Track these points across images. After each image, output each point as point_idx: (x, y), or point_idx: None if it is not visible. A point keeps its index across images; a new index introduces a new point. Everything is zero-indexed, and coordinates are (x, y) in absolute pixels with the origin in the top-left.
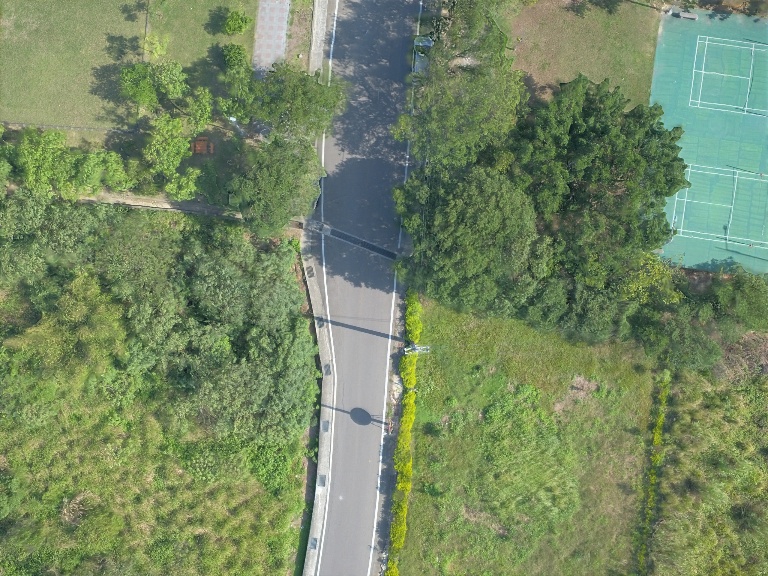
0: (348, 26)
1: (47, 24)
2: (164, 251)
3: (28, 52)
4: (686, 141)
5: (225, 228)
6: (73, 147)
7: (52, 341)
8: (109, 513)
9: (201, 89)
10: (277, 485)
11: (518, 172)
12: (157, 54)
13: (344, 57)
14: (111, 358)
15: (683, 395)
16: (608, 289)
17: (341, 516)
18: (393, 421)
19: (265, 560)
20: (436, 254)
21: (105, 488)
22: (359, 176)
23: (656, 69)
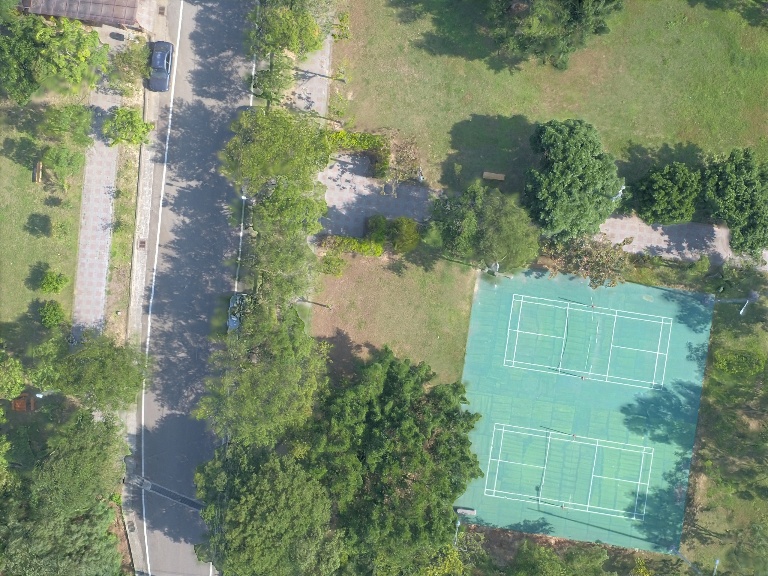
0: (167, 281)
1: None
2: None
3: None
4: (500, 401)
5: None
6: None
7: None
8: None
9: (11, 360)
10: None
11: (315, 459)
12: None
13: (163, 313)
14: None
15: None
16: (408, 569)
17: None
18: None
19: None
20: (226, 551)
21: None
22: (178, 433)
23: (471, 328)
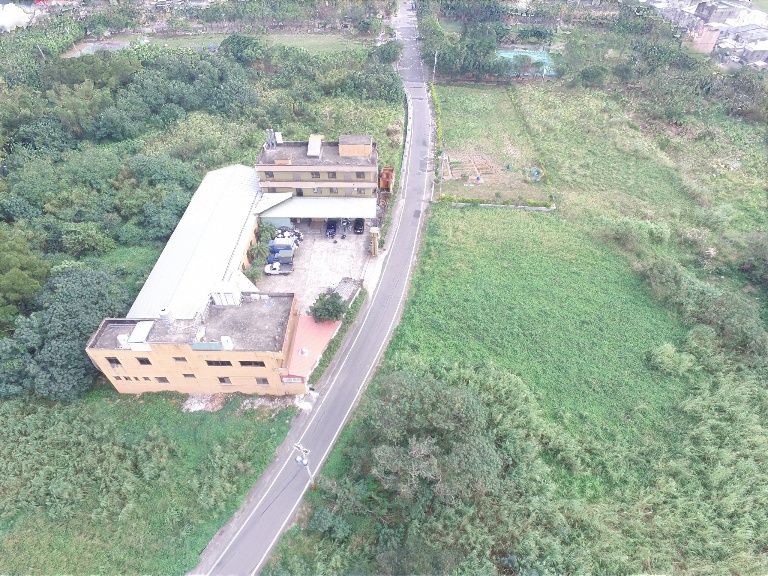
0: None
1: None
2: None
3: None
4: None
5: None
6: None
7: None
8: None
9: None
10: None
11: None
12: None
13: (401, 58)
14: None
15: None
16: None
17: (418, 113)
18: None
19: None
20: None
21: None
22: None
23: None
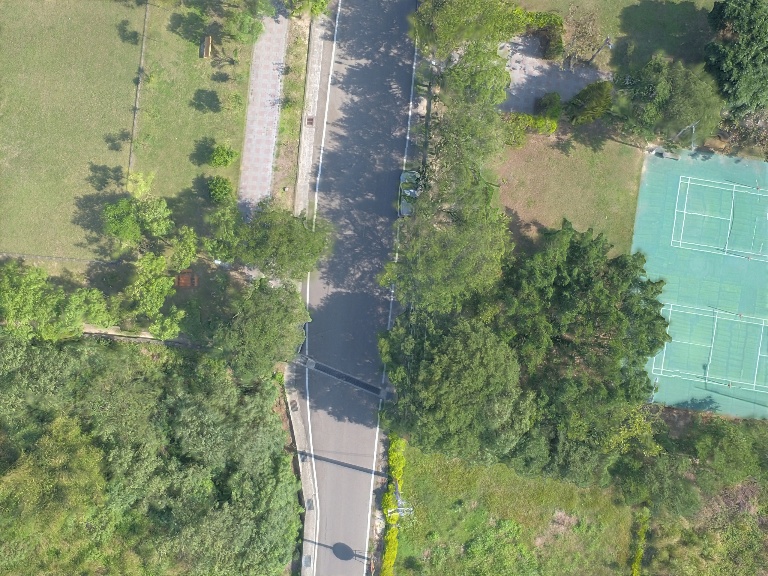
0: (334, 159)
1: (29, 151)
2: (147, 397)
3: (9, 179)
4: (667, 281)
5: (208, 361)
6: (54, 276)
7: (31, 480)
8: None
9: (186, 228)
10: None
11: (502, 323)
12: (141, 191)
13: (330, 190)
14: (92, 502)
15: (662, 532)
16: (590, 437)
17: None
18: (375, 556)
19: None
20: (420, 410)
21: None
22: (344, 310)
23: (639, 208)
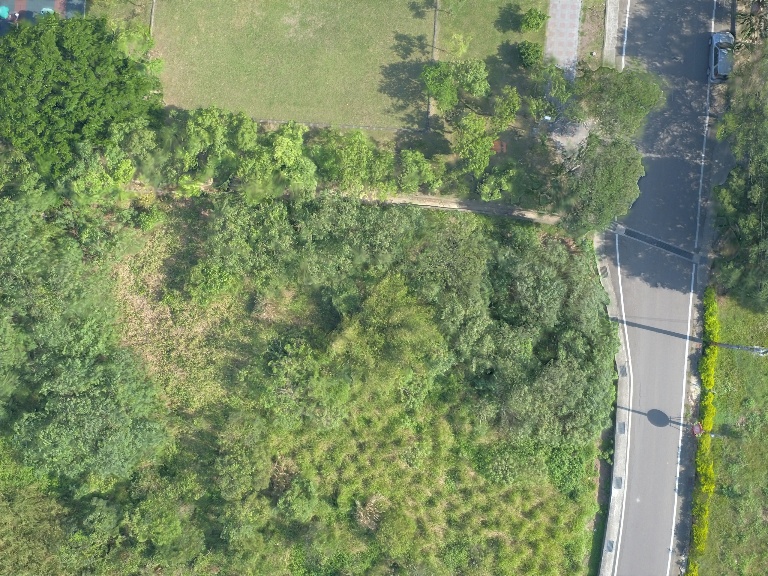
0: (641, 23)
1: (333, 22)
2: (484, 252)
3: (314, 50)
4: None
5: None
6: None
7: (357, 343)
8: (402, 516)
9: (508, 87)
10: (572, 487)
11: None
12: None
13: (637, 54)
14: (426, 360)
15: None
16: None
17: (638, 518)
18: (692, 423)
19: (561, 563)
20: None
21: (397, 491)
22: (654, 175)
23: None
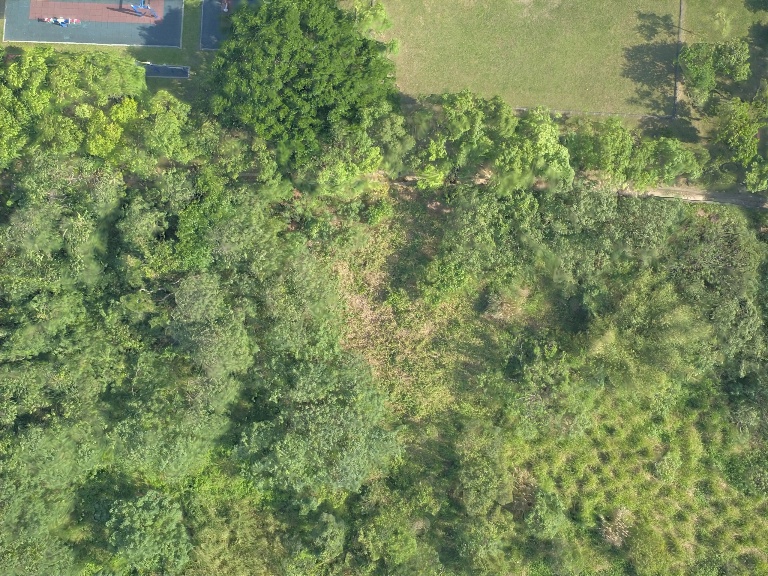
0: None
1: (570, 1)
2: (763, 246)
3: (550, 32)
4: None
5: None
6: None
7: (612, 345)
8: (651, 531)
9: None
10: None
11: None
12: None
13: None
14: None
15: None
16: None
17: None
18: None
19: None
20: None
21: (644, 504)
22: None
23: None
